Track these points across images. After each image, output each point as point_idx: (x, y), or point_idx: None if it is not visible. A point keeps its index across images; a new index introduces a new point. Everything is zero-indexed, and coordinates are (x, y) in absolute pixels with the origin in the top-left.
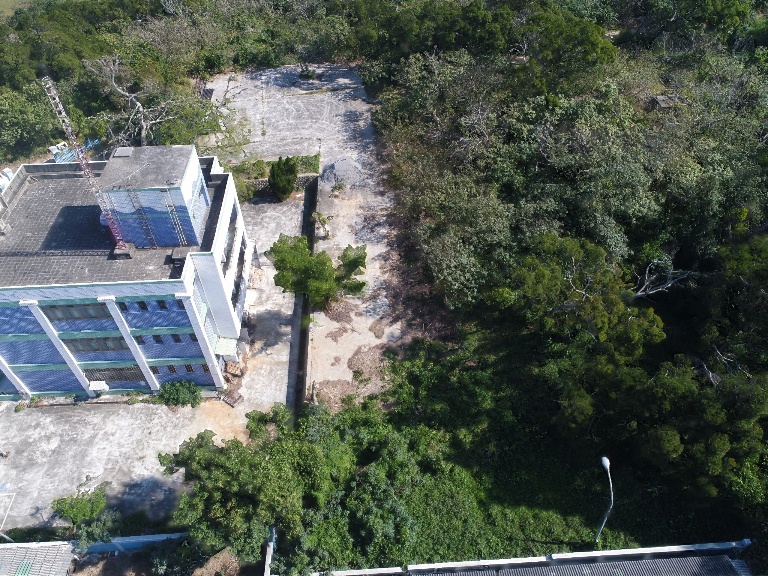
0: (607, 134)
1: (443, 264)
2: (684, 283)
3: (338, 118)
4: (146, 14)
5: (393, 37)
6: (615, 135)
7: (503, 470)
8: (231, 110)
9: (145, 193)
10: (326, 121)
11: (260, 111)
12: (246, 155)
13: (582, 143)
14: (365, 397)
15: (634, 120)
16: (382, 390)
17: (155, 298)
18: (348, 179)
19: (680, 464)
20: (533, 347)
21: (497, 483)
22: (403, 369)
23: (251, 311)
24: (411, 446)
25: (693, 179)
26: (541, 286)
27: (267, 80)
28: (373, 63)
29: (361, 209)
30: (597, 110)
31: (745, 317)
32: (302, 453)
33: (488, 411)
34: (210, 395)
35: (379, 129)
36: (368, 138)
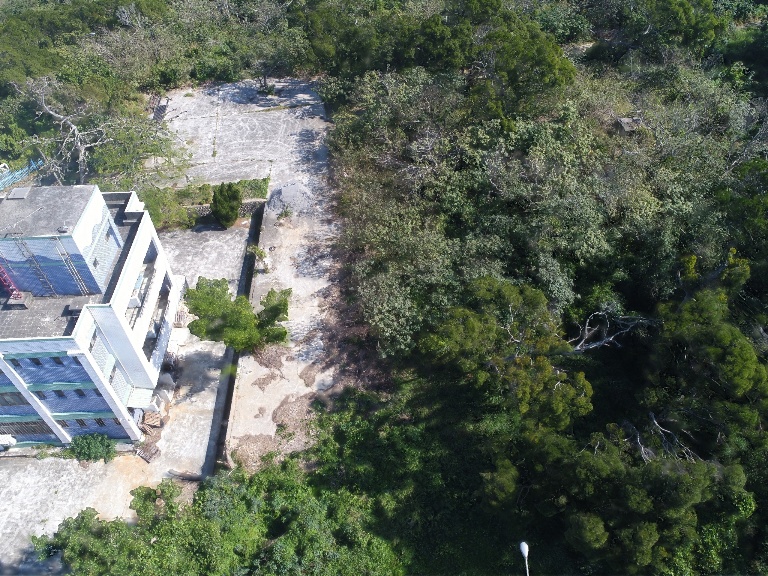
0: (562, 162)
1: (374, 309)
2: (633, 331)
3: (293, 138)
4: (102, 26)
5: (354, 51)
6: (571, 163)
7: (426, 542)
8: (172, 133)
9: (34, 241)
10: (280, 141)
11: (213, 130)
12: (190, 180)
13: (535, 172)
14: (286, 455)
15: (593, 146)
16: (305, 447)
17: (47, 355)
18: (295, 206)
19: (607, 551)
20: (470, 400)
21: (418, 558)
22: (330, 423)
23: (180, 352)
24: (330, 513)
25: (648, 215)
26: (470, 340)
27: (224, 96)
28: (330, 79)
29: (306, 239)
30: (555, 135)
31: (697, 370)
32: (195, 532)
33: (415, 474)
34: (126, 448)
35: (331, 152)
36: (321, 160)
